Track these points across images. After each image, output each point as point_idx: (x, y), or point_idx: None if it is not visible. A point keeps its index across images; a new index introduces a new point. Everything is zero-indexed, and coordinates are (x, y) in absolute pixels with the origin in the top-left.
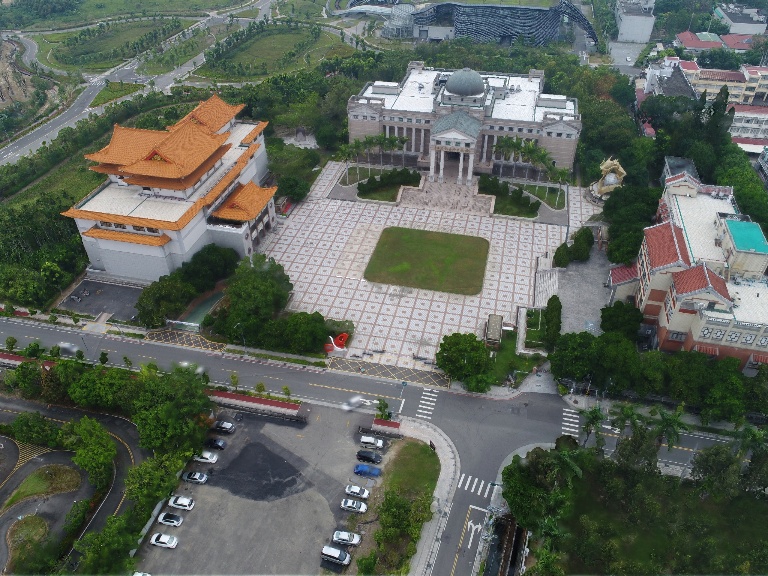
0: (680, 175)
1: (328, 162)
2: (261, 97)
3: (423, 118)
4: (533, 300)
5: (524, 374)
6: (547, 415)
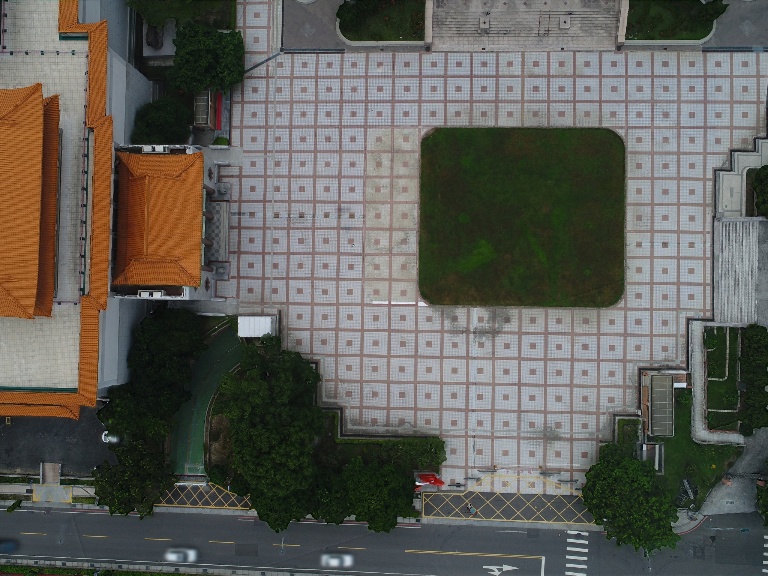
0: None
1: None
2: None
3: None
4: (712, 297)
5: (709, 485)
6: (742, 552)
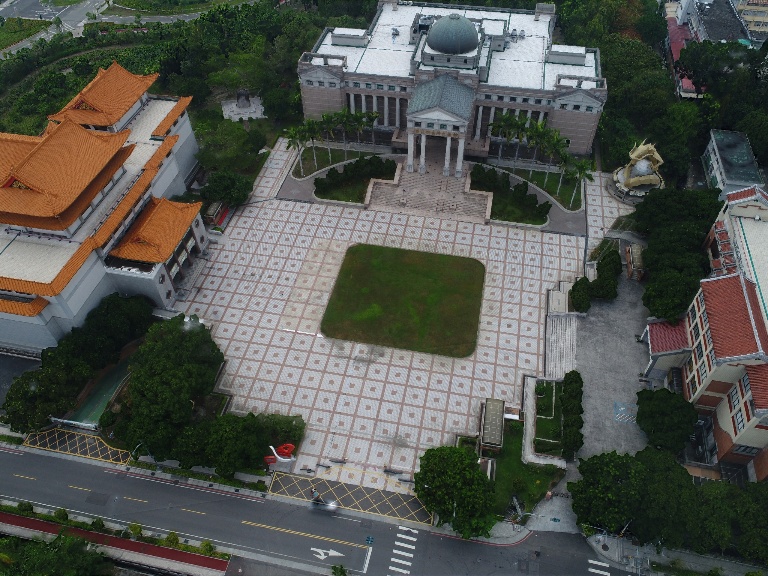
0: (748, 190)
1: (278, 139)
2: (191, 46)
3: (398, 84)
4: (543, 363)
5: (534, 500)
6: (566, 573)
